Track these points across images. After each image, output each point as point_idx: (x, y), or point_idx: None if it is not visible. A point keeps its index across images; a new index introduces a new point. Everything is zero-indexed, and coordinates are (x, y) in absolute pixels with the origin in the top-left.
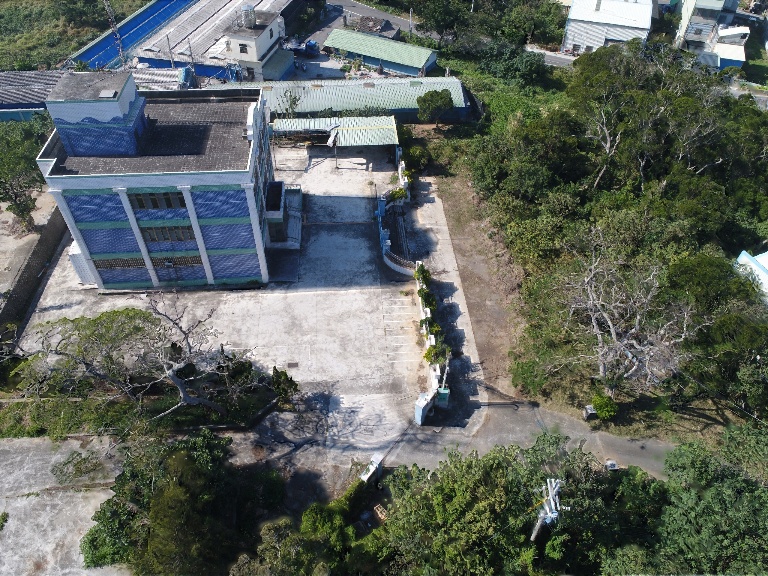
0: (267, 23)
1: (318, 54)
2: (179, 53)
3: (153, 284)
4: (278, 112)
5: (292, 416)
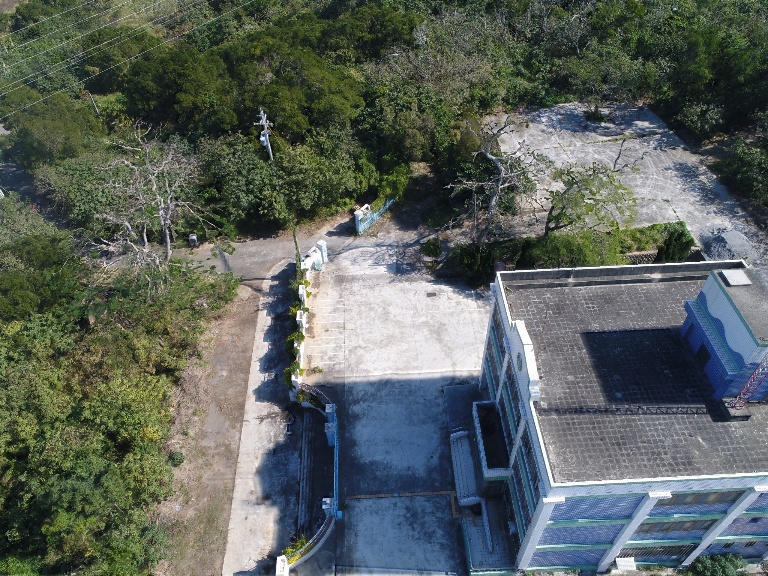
0: None
1: None
2: None
3: None
4: None
5: (425, 259)
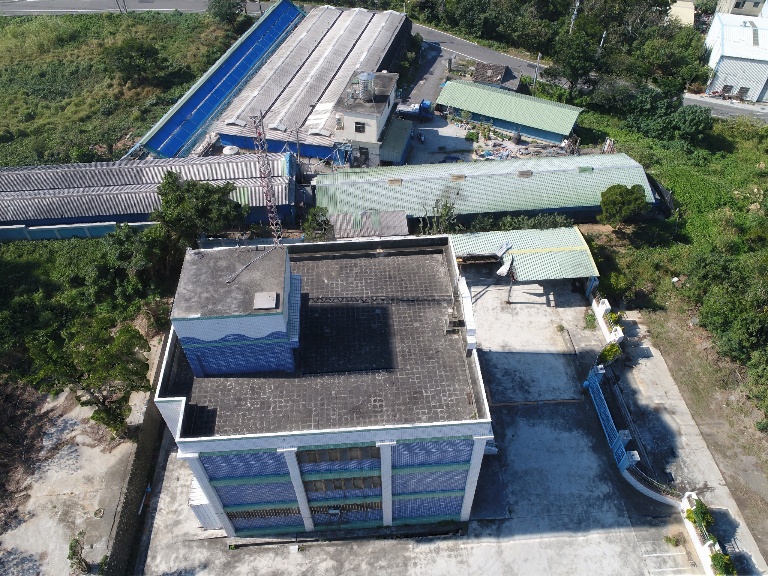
0: (387, 92)
1: (433, 116)
2: (271, 128)
3: (305, 529)
4: (414, 216)
5: None
